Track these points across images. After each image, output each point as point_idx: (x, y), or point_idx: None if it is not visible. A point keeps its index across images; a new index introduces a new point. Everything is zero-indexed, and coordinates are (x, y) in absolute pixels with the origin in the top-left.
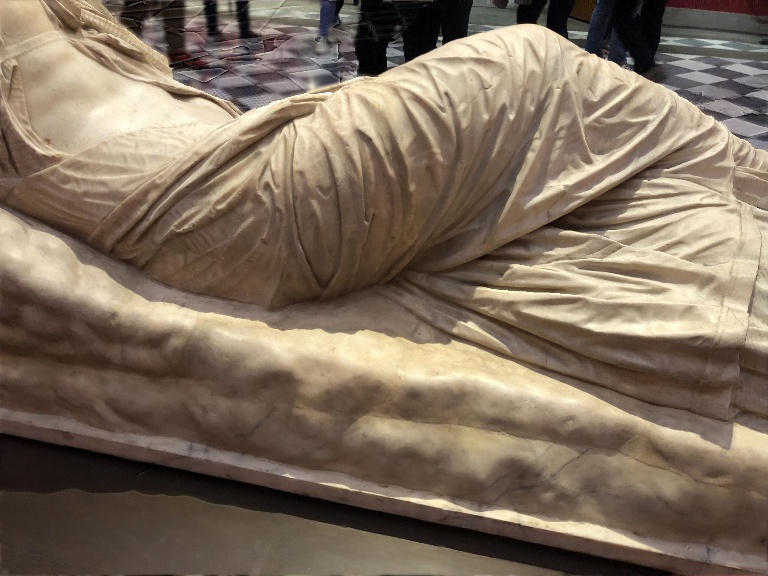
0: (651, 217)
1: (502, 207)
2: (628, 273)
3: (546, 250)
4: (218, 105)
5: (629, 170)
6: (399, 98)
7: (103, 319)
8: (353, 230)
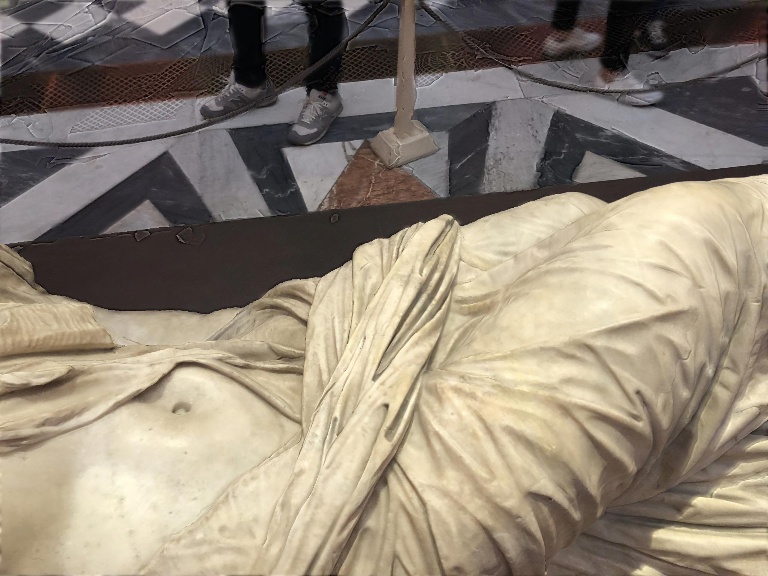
0: None
1: (682, 451)
2: None
3: (729, 470)
4: (207, 369)
5: None
6: (573, 421)
7: None
8: None
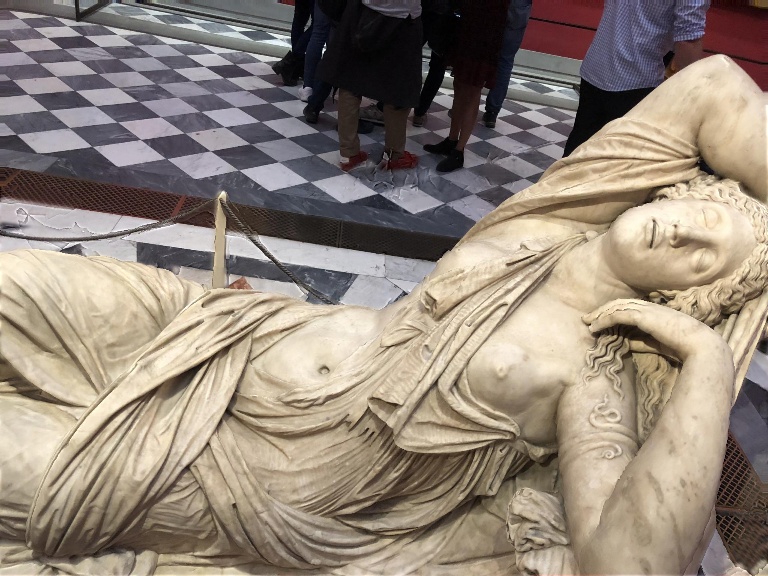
0: None
1: None
2: None
3: None
4: None
5: None
6: None
7: None
8: None
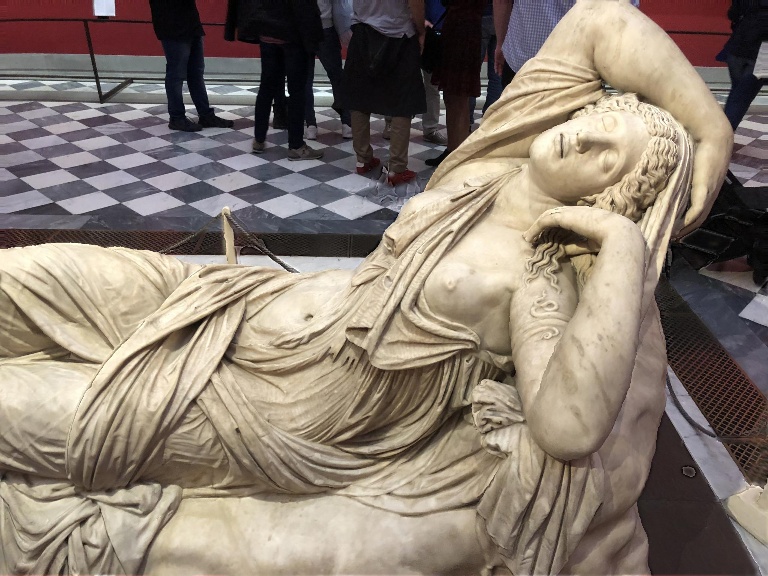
0: None
1: None
2: None
3: None
4: None
5: None
6: None
7: None
8: None
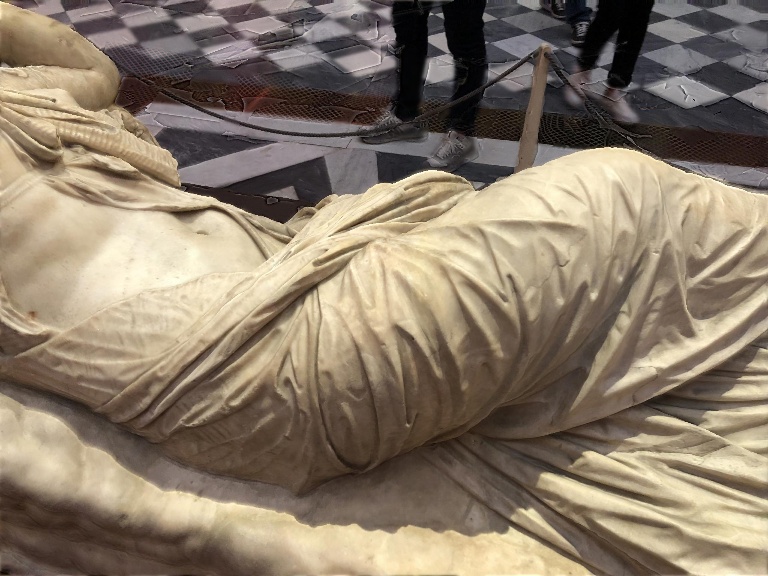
0: (766, 400)
1: (575, 388)
2: (733, 484)
3: (628, 435)
4: (232, 218)
5: (742, 343)
6: (448, 281)
7: (111, 523)
8: (392, 431)
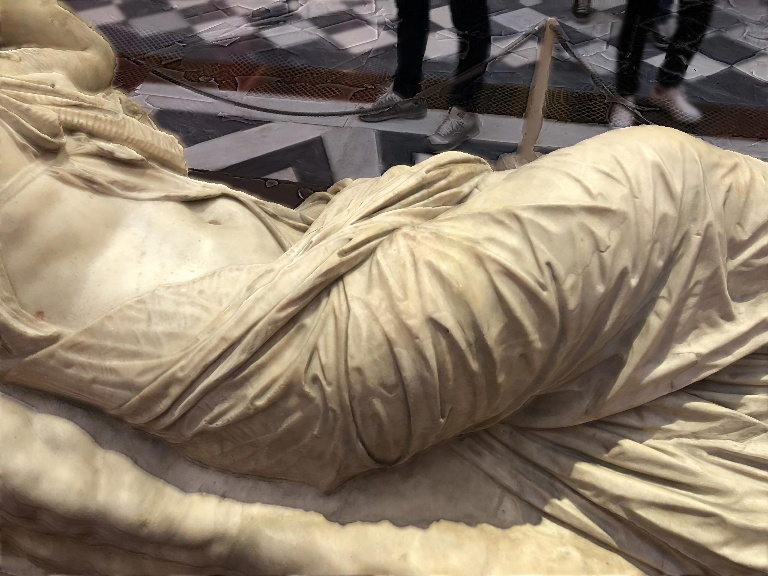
0: None
1: (612, 376)
2: None
3: (665, 422)
4: (244, 206)
5: None
6: (484, 270)
7: (134, 528)
8: (425, 426)
